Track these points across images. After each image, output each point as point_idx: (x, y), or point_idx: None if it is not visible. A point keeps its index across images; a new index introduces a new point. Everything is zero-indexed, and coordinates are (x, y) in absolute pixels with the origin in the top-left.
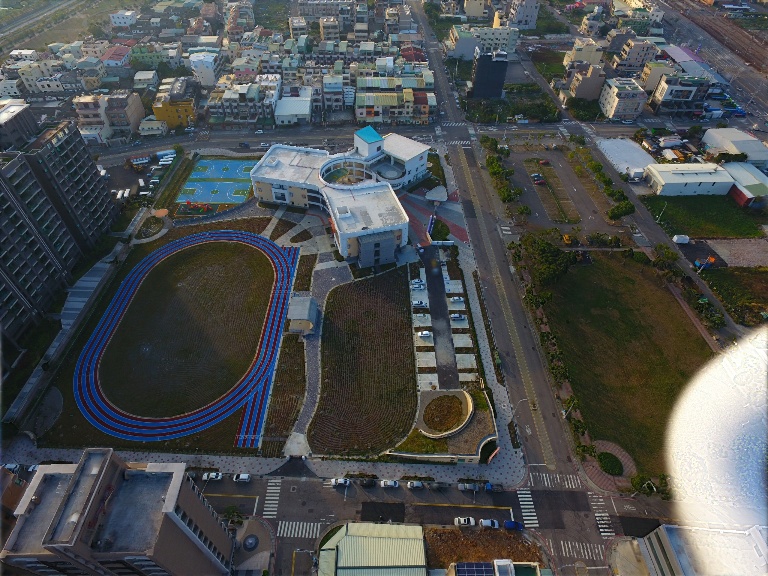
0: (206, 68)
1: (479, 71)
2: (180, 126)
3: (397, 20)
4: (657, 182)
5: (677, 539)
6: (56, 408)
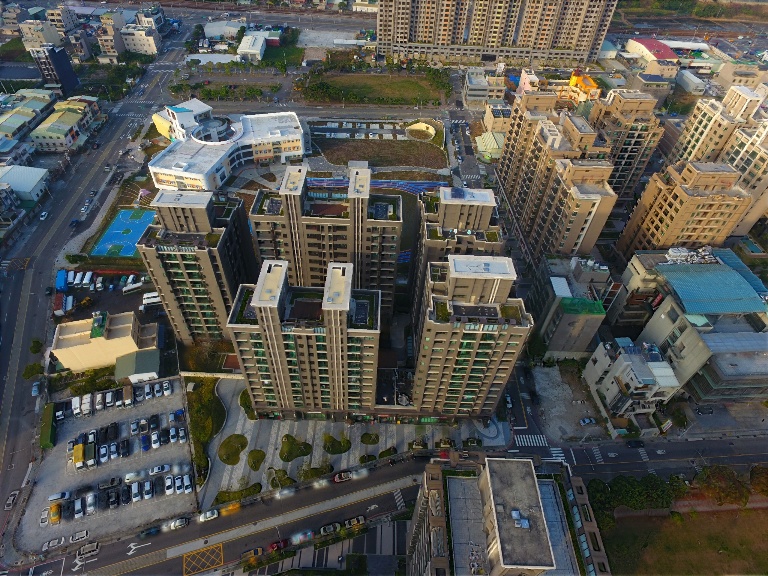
0: None
1: (56, 67)
2: None
3: None
4: None
5: None
6: None
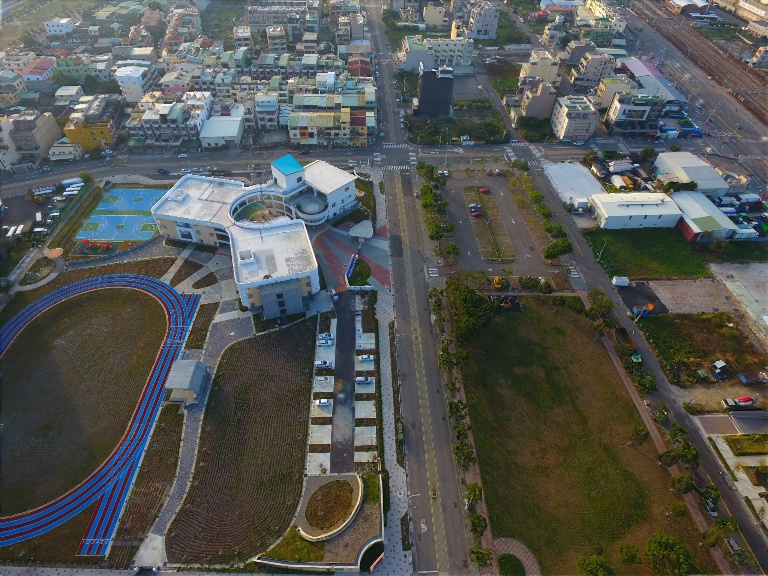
0: (133, 84)
1: (424, 88)
2: (97, 149)
3: (349, 30)
4: (600, 215)
5: None
6: None
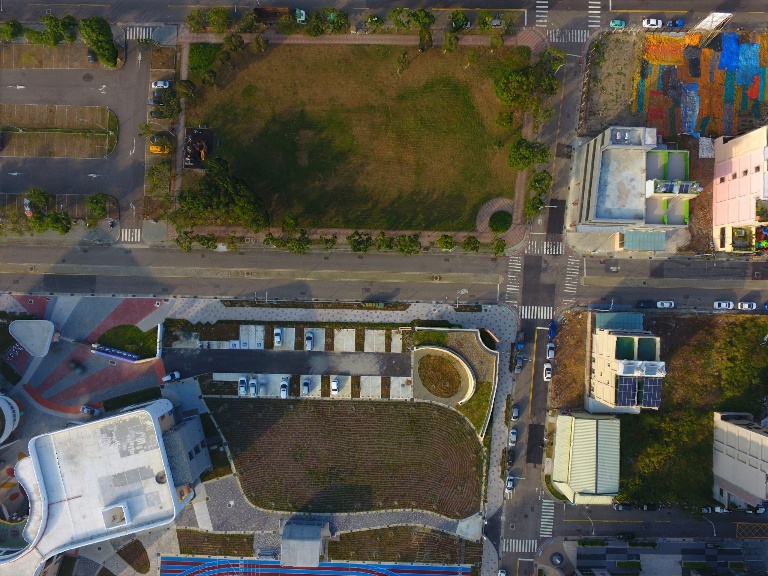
0: None
1: None
2: None
3: None
4: None
5: (601, 210)
6: None
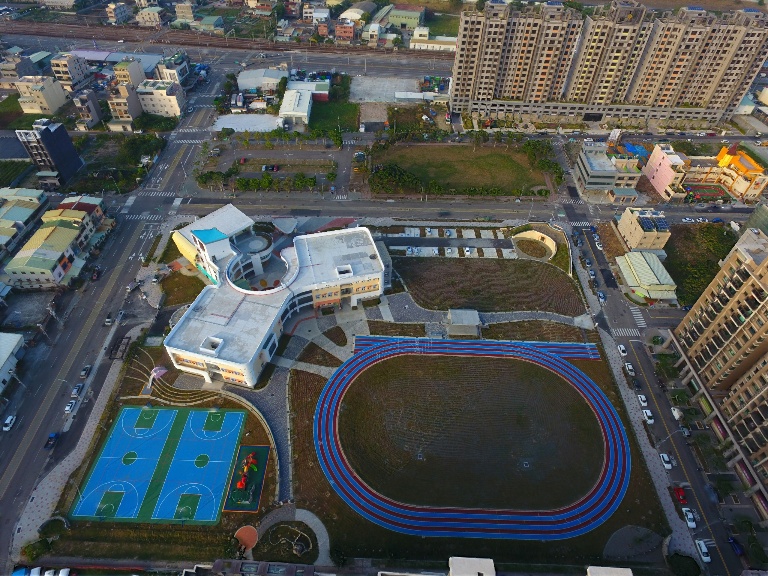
0: None
1: (50, 151)
2: None
3: None
4: (302, 116)
5: None
6: (627, 535)
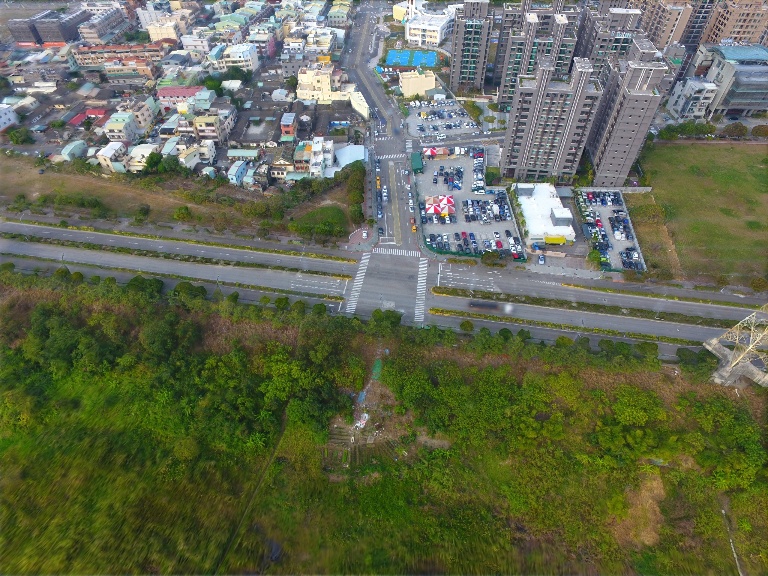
0: (254, 52)
1: None
2: None
3: None
4: None
5: None
6: None
